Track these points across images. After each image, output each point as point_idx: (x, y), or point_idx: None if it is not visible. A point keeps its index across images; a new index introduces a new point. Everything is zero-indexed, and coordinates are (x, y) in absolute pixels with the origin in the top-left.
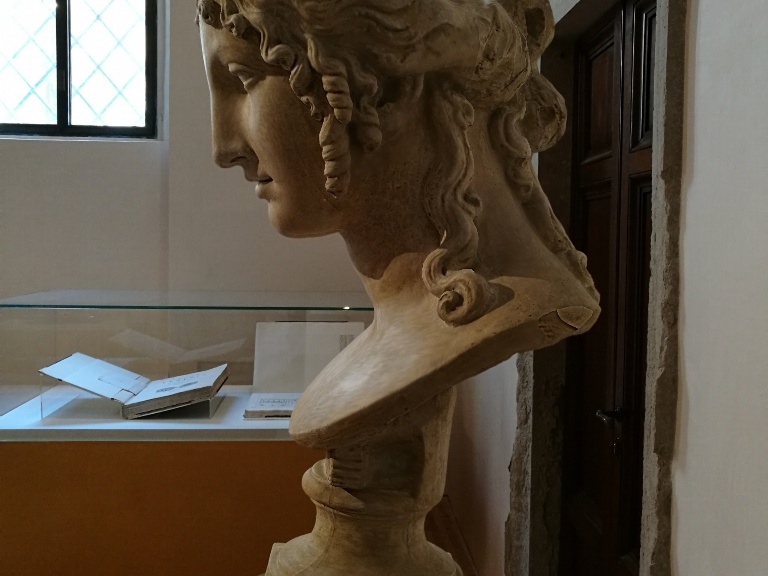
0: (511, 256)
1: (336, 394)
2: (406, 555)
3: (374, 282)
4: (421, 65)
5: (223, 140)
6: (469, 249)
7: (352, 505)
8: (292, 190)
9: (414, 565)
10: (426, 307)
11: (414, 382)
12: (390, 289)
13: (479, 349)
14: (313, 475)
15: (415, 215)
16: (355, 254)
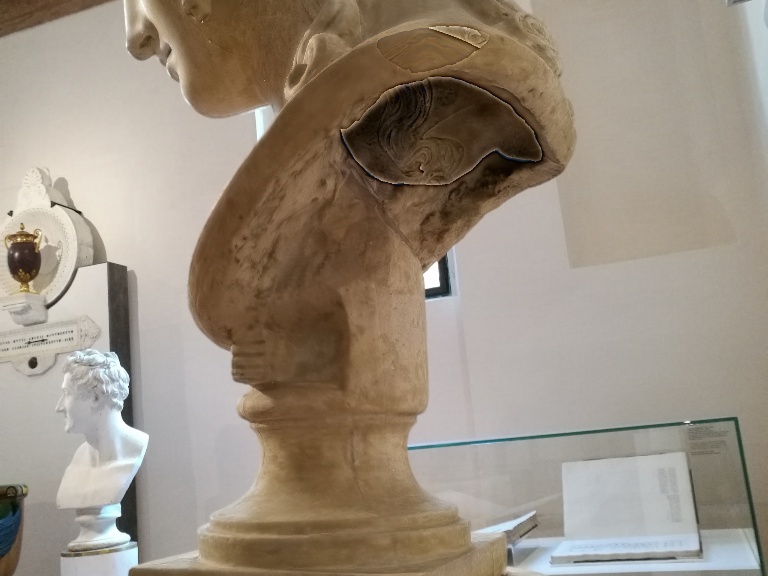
0: (400, 21)
1: None
2: (350, 480)
3: None
4: None
5: (130, 26)
6: (338, 22)
7: (261, 405)
8: (178, 43)
9: (360, 493)
10: None
11: (236, 172)
12: None
13: (299, 100)
14: None
15: (298, 22)
16: None
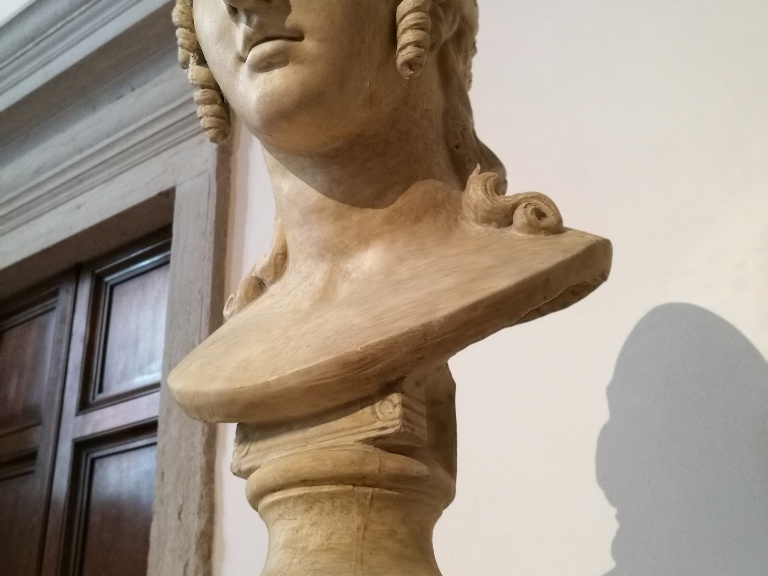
0: None
1: (408, 300)
2: None
3: (374, 212)
4: (469, 2)
5: None
6: None
7: (416, 469)
8: (340, 55)
9: None
10: (464, 236)
11: (558, 263)
12: (402, 220)
13: (597, 248)
14: (314, 450)
15: (440, 144)
16: (350, 176)
